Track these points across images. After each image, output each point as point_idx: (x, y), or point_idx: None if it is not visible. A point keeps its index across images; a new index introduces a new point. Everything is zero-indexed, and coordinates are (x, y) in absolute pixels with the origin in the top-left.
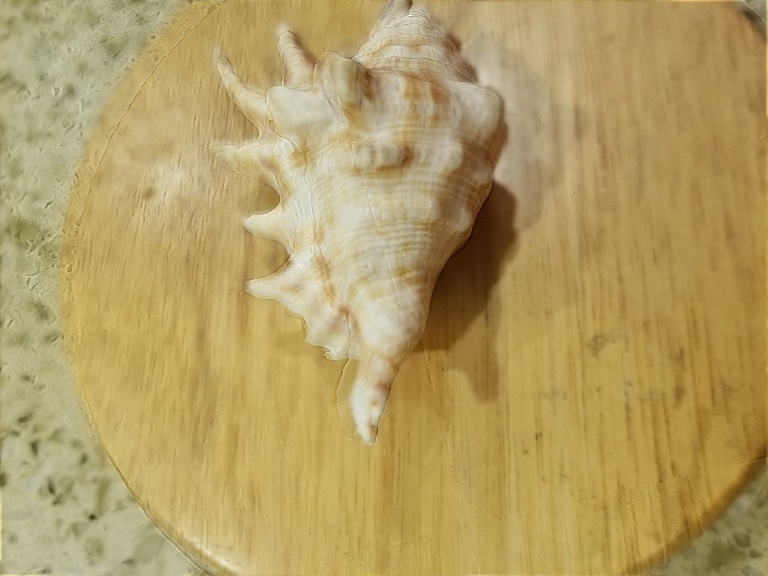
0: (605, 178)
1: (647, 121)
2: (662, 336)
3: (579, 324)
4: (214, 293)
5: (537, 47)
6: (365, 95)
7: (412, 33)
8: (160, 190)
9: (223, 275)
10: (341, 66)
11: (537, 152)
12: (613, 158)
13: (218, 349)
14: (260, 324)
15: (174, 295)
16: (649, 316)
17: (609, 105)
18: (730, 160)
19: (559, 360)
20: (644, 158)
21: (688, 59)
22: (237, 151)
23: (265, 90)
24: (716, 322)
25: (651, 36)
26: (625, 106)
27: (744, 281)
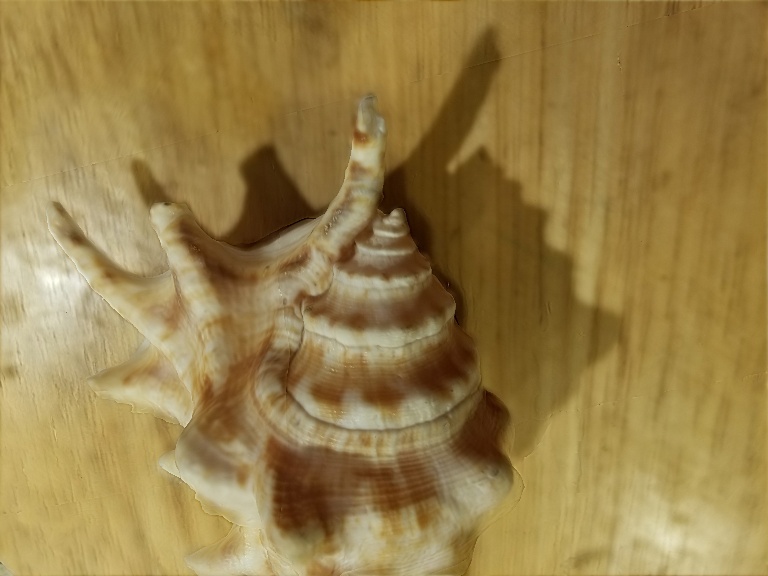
0: (616, 394)
1: (686, 328)
2: (635, 560)
3: (556, 543)
4: (133, 485)
5: (563, 184)
6: (344, 570)
7: (395, 346)
8: (8, 346)
9: (139, 466)
10: (310, 575)
11: (540, 354)
12: (632, 369)
13: (156, 542)
14: (200, 520)
15: (80, 482)
16: (627, 542)
17: (644, 294)
18: (766, 388)
19: (530, 574)
20: (669, 375)
21: (766, 238)
22: (127, 390)
23: (130, 200)
24: (690, 552)
25: (730, 192)
26: (664, 300)
27: (730, 516)
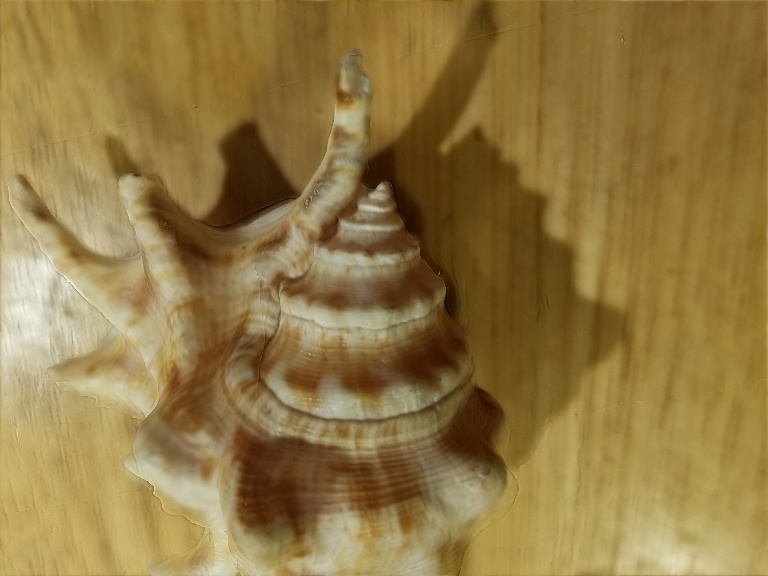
0: (619, 398)
1: (694, 326)
2: None
3: (553, 561)
4: (99, 490)
5: (563, 168)
6: None
7: (378, 328)
8: None
9: (106, 469)
10: None
11: (537, 352)
12: (635, 370)
13: (122, 554)
14: (171, 531)
15: (43, 487)
16: (630, 561)
17: (649, 289)
18: None
19: None
20: (675, 377)
21: None
22: (90, 381)
23: (103, 179)
24: (698, 573)
25: (740, 178)
26: (670, 295)
27: (742, 534)
